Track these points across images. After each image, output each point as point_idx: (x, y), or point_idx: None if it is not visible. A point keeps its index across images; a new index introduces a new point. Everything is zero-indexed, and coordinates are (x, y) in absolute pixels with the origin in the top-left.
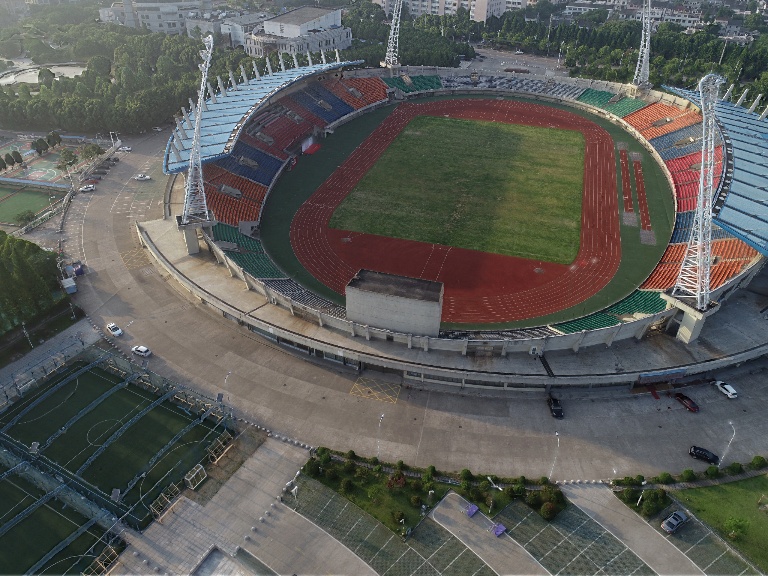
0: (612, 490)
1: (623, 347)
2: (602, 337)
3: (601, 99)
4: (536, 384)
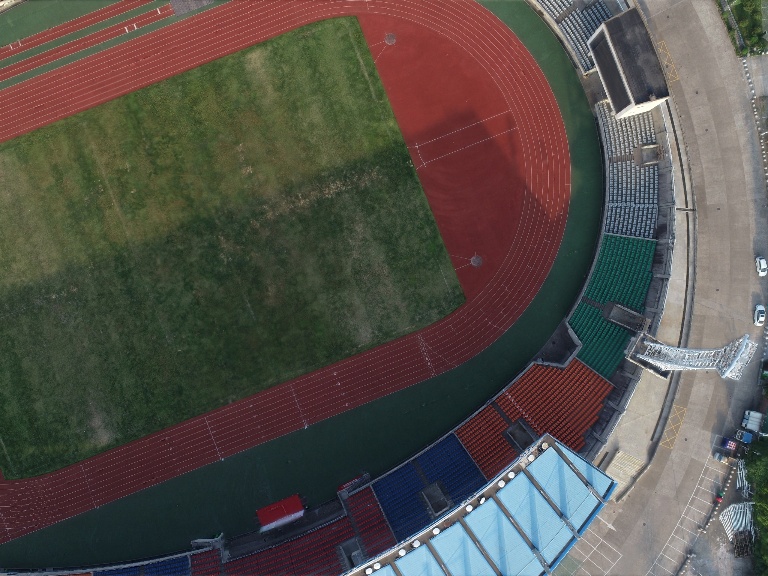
0: None
1: None
2: None
3: None
4: None
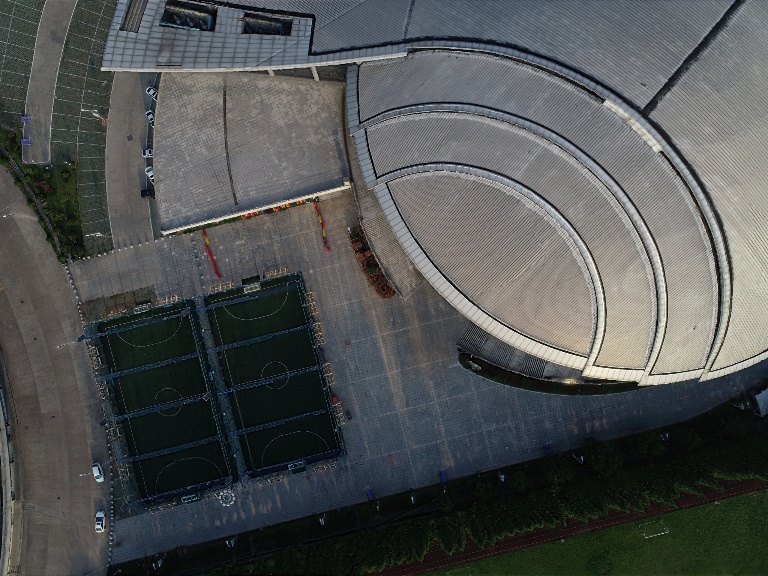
0: None
1: None
2: None
3: None
4: None
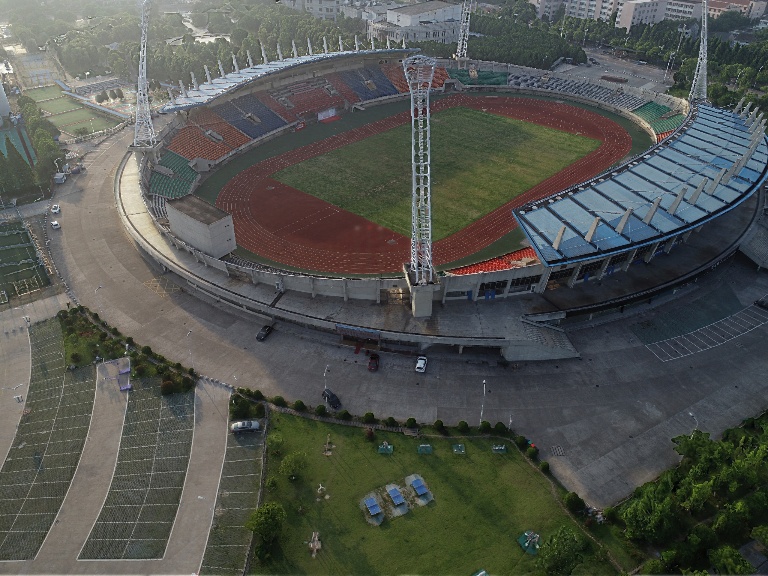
0: (231, 394)
1: (356, 304)
2: (335, 289)
3: (655, 113)
4: (256, 309)
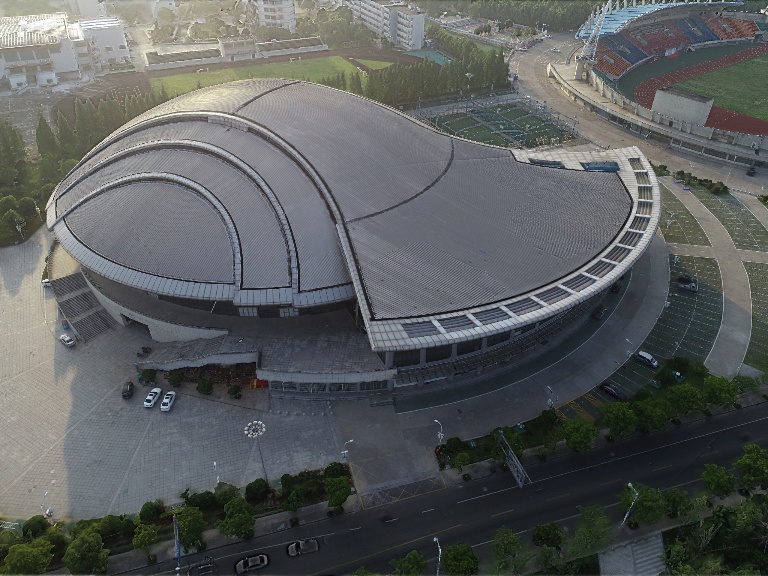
0: (757, 197)
1: None
2: None
3: None
4: (744, 157)
